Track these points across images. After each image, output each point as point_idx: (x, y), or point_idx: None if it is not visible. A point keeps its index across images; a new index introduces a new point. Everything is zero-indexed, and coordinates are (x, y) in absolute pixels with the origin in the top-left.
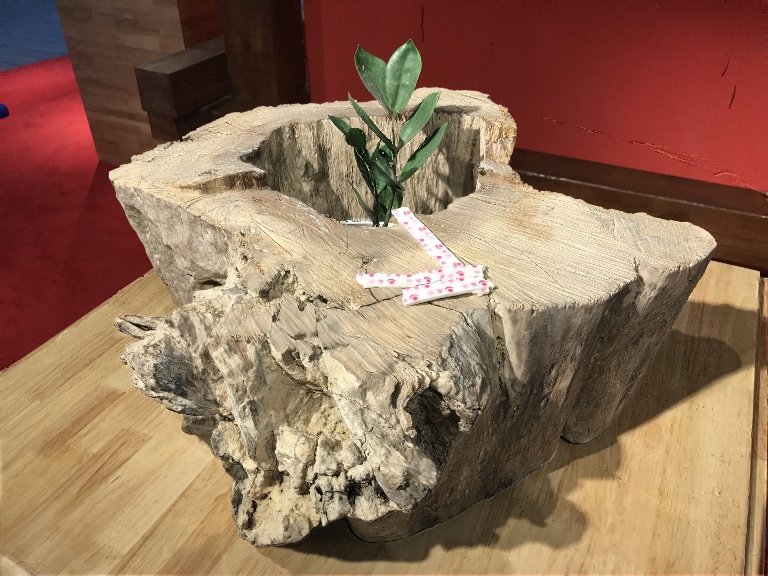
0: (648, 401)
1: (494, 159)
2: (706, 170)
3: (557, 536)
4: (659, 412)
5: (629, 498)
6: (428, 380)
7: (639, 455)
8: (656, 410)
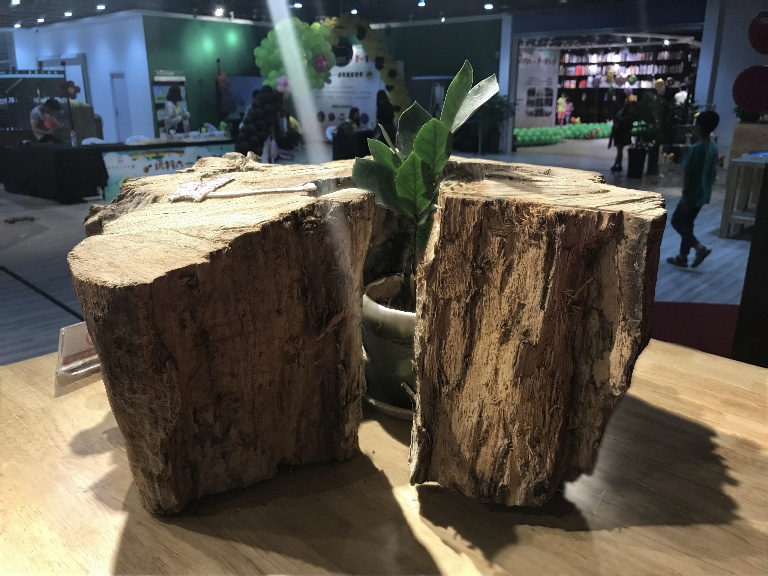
0: (143, 569)
1: None
2: (7, 53)
3: (88, 435)
4: (117, 570)
5: (61, 488)
6: (122, 190)
7: (89, 518)
8: (123, 570)
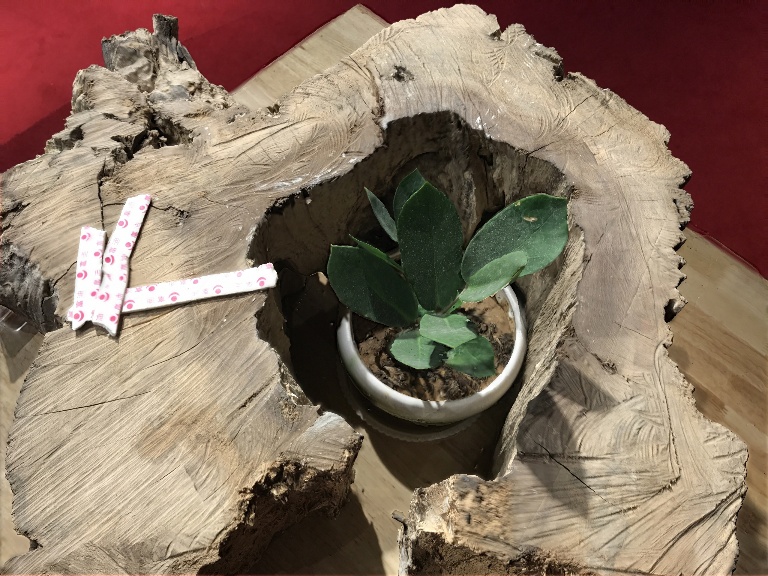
0: None
1: (442, 503)
2: None
3: None
4: None
5: None
6: None
7: None
8: None
